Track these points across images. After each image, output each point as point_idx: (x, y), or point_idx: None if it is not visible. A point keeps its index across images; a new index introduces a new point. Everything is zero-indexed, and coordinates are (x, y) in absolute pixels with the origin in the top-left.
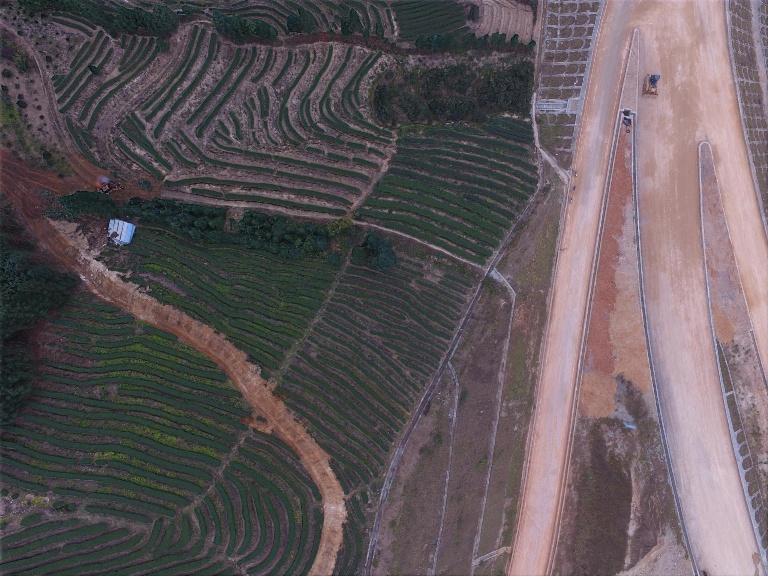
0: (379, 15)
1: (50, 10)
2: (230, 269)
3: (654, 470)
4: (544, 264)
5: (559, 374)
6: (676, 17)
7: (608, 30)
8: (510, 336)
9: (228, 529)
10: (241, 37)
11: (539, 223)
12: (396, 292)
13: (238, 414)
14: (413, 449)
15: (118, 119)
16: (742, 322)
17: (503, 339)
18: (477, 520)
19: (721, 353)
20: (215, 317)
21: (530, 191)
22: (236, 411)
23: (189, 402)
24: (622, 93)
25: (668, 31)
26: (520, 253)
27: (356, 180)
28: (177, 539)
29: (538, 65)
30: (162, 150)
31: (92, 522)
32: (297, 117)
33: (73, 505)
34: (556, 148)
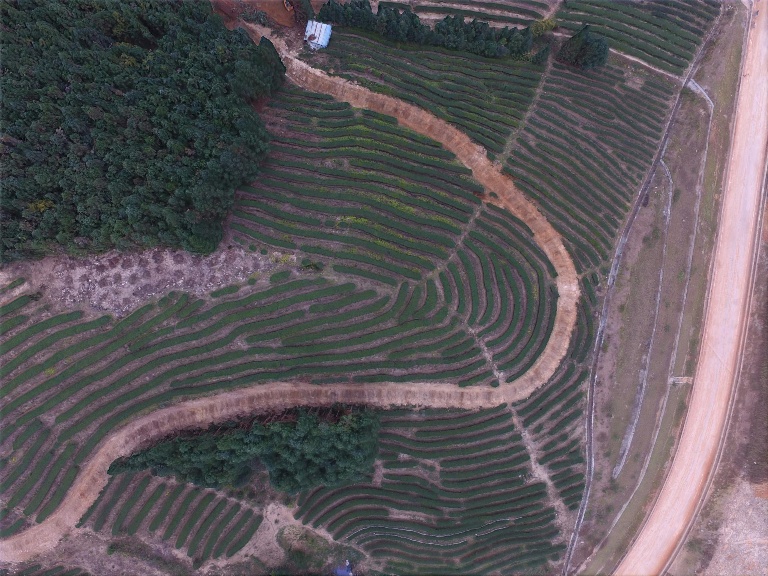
0: None
1: None
2: (436, 67)
3: None
4: (728, 89)
5: (741, 202)
6: None
7: None
8: (708, 148)
9: (470, 298)
10: None
11: (728, 42)
12: (602, 93)
13: (471, 189)
14: (636, 237)
15: None
16: None
17: (701, 151)
18: (674, 336)
19: None
20: None
21: (715, 13)
22: (470, 185)
23: None
24: None
25: None
26: (714, 68)
27: None
28: (421, 305)
29: None
30: None
31: (338, 283)
32: None
33: (321, 263)
34: None
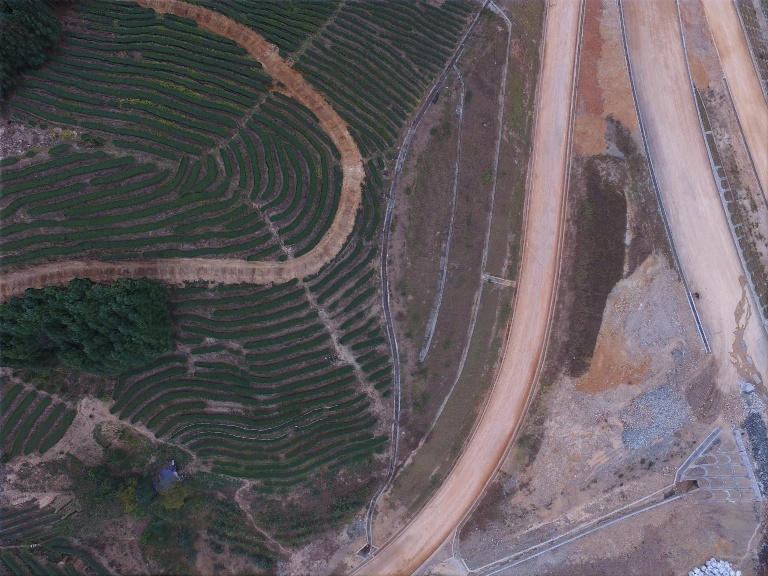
0: None
1: None
2: None
3: (645, 201)
4: (535, 17)
5: (553, 119)
6: None
7: None
8: (508, 62)
9: (252, 175)
10: None
11: None
12: (402, 8)
13: (259, 79)
14: (424, 129)
15: None
16: (715, 70)
17: (502, 65)
18: (484, 234)
19: (699, 97)
20: (233, 12)
21: None
22: (257, 75)
23: None
24: None
25: None
26: None
27: None
28: None
29: None
30: None
31: None
32: None
33: (101, 138)
34: None
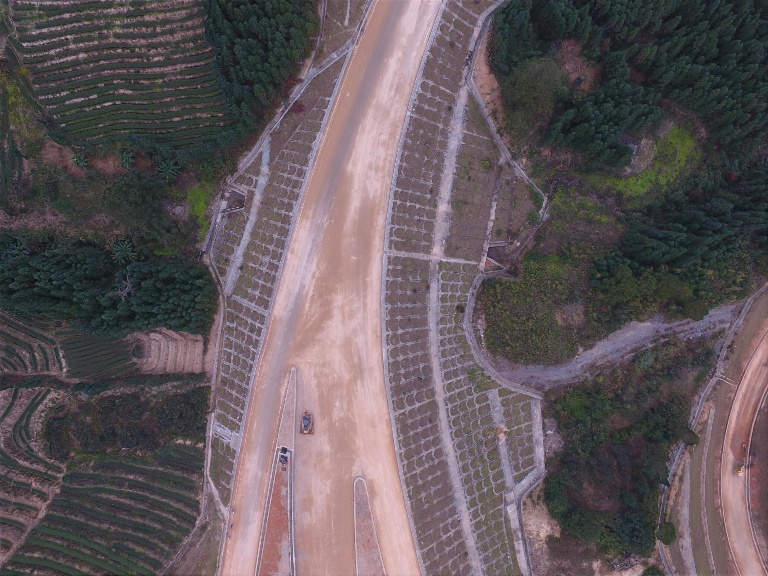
0: (46, 354)
1: None
2: None
3: None
4: None
5: None
6: (334, 354)
7: (267, 368)
8: None
9: None
10: None
11: (187, 570)
12: None
13: None
14: None
15: None
16: None
17: None
18: None
19: None
20: None
21: (185, 532)
22: None
23: None
24: (279, 431)
25: (326, 368)
26: None
27: (11, 529)
28: None
29: (216, 386)
30: None
31: None
32: None
33: None
34: (220, 480)
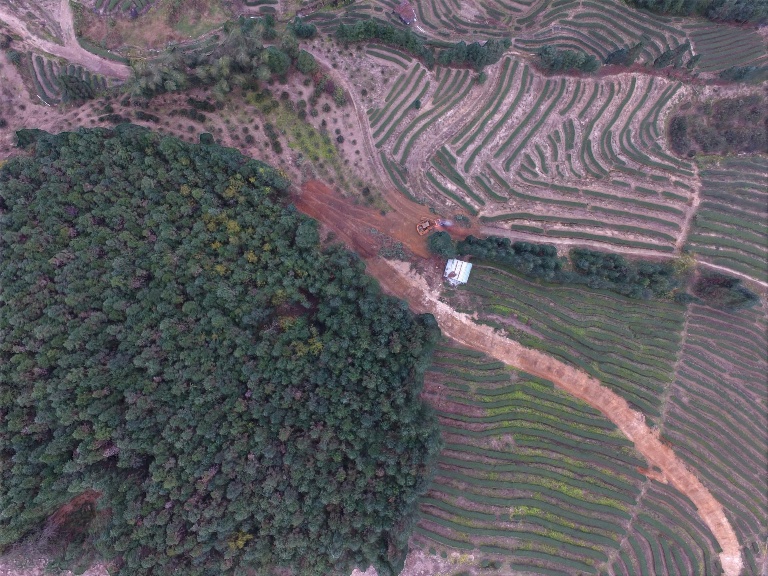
0: None
1: (364, 42)
2: (581, 310)
3: None
4: None
5: None
6: None
7: None
8: None
9: None
10: (561, 70)
11: None
12: (745, 332)
13: (635, 464)
14: None
15: (428, 153)
16: None
17: None
18: None
19: None
20: (583, 361)
21: None
22: (634, 461)
23: (585, 452)
24: None
25: None
26: None
27: (671, 215)
28: None
29: None
30: (473, 185)
31: None
32: (598, 149)
33: None
34: None
